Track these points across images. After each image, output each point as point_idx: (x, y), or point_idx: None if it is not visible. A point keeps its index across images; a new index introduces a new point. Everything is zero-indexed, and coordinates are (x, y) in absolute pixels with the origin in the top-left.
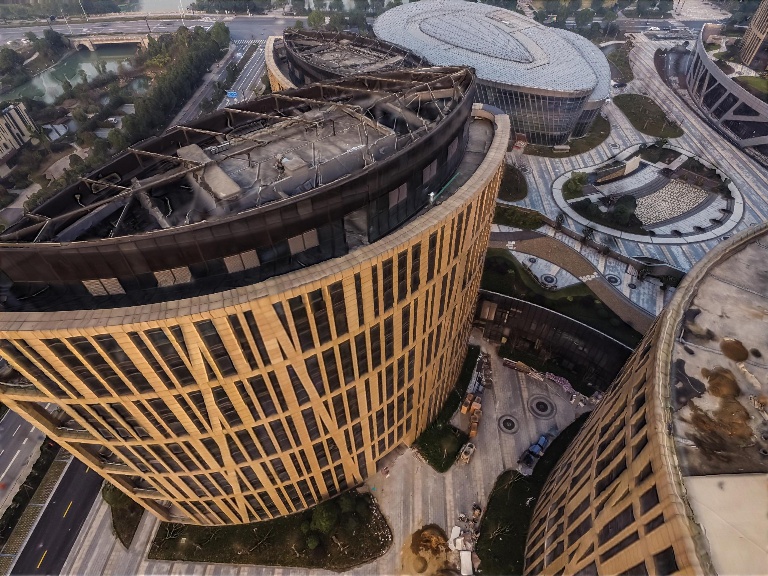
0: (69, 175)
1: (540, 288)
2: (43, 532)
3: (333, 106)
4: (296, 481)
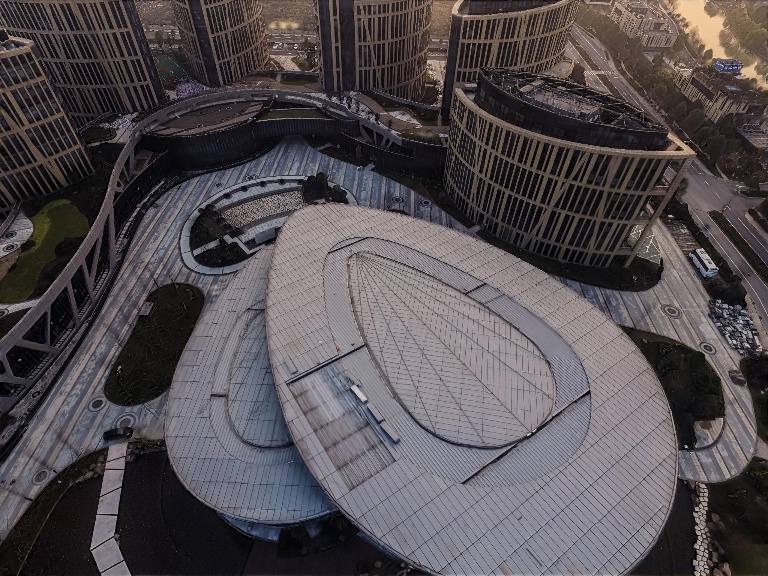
0: None
1: None
2: None
3: None
4: None
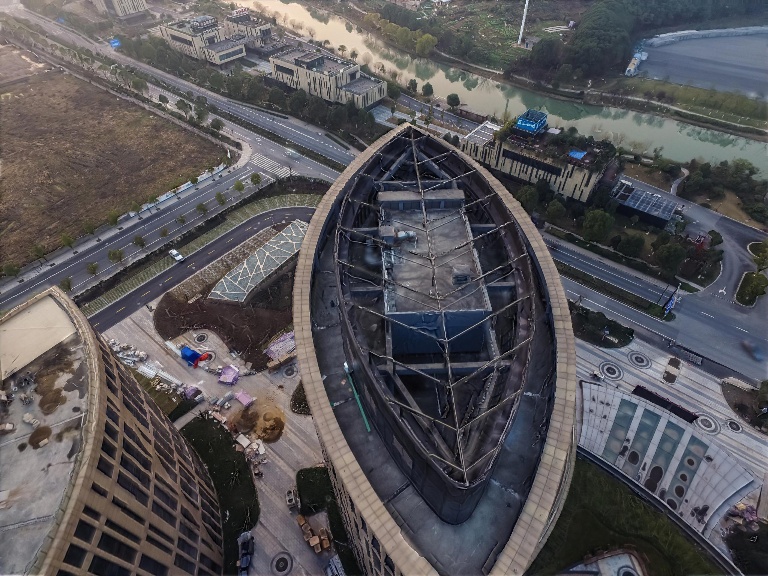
0: None
1: None
2: None
3: (489, 304)
4: None
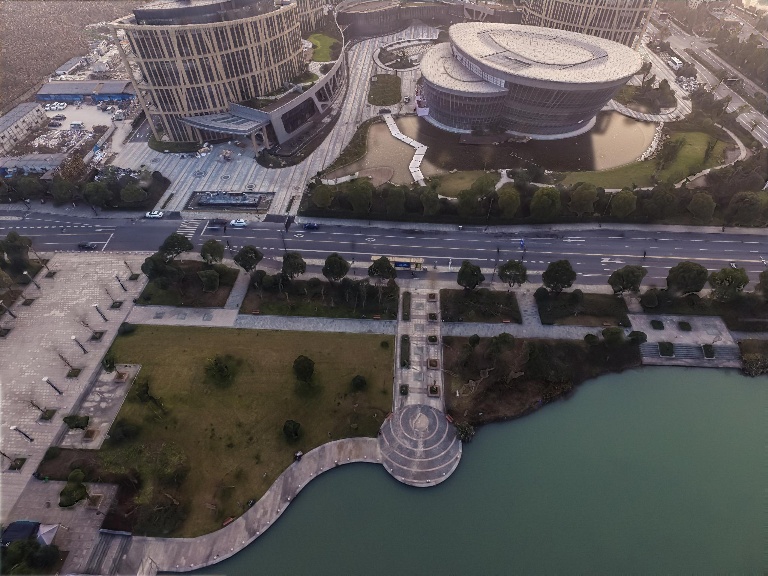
0: None
1: None
2: None
3: None
4: None
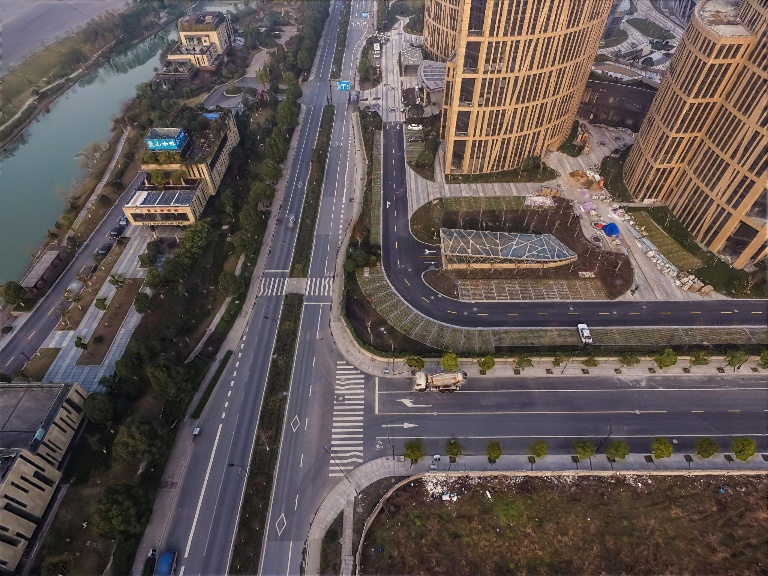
0: (280, 57)
1: (614, 80)
2: (388, 179)
3: None
4: (524, 134)
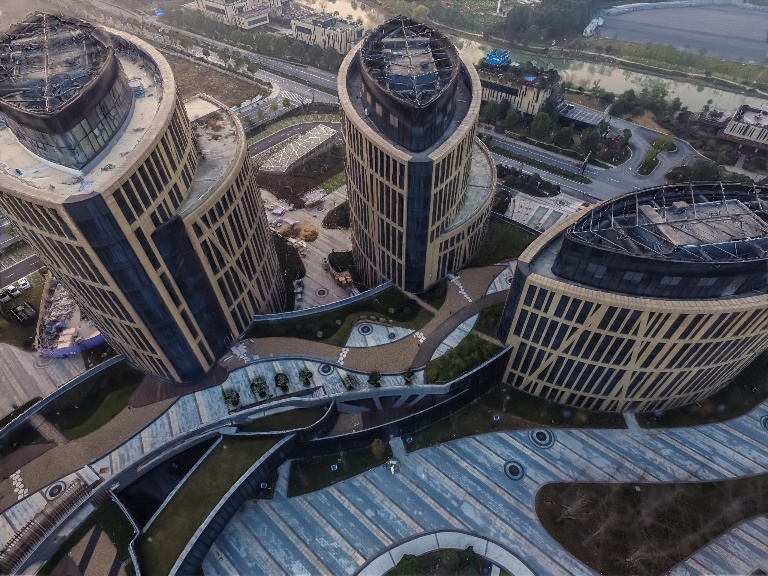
0: None
1: None
2: None
3: None
4: None
